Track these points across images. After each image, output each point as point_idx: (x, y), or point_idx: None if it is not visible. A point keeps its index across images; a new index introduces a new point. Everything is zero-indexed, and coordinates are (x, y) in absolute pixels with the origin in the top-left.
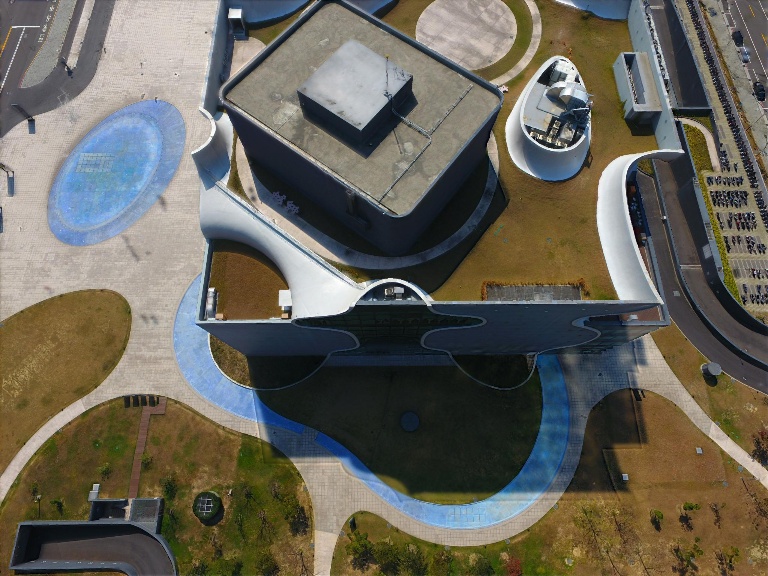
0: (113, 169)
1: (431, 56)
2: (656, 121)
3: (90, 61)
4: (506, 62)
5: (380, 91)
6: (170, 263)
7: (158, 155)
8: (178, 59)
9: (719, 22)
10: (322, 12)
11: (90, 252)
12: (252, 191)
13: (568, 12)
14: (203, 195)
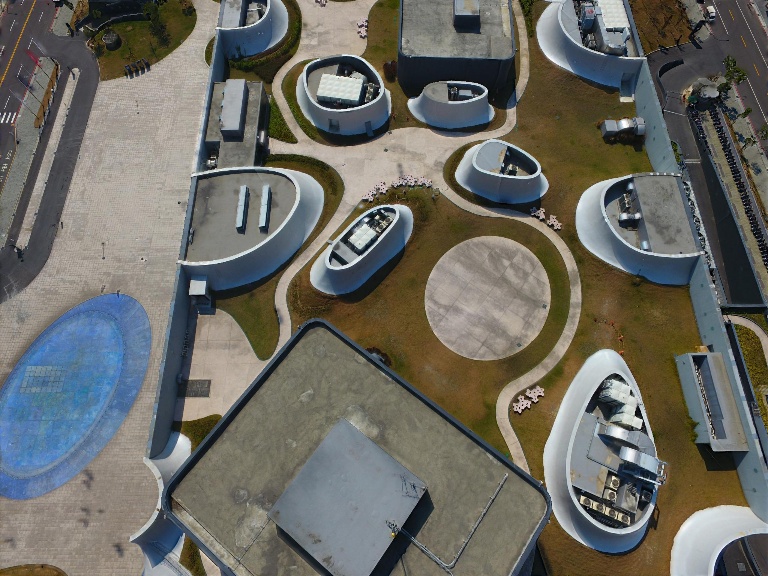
0: (64, 388)
1: (450, 422)
2: (739, 456)
3: (44, 239)
4: (539, 346)
5: (382, 518)
6: (127, 526)
7: (118, 369)
8: (146, 238)
9: (765, 182)
10: (305, 343)
11: (31, 509)
12: (213, 566)
13: (614, 275)
14: (148, 575)
